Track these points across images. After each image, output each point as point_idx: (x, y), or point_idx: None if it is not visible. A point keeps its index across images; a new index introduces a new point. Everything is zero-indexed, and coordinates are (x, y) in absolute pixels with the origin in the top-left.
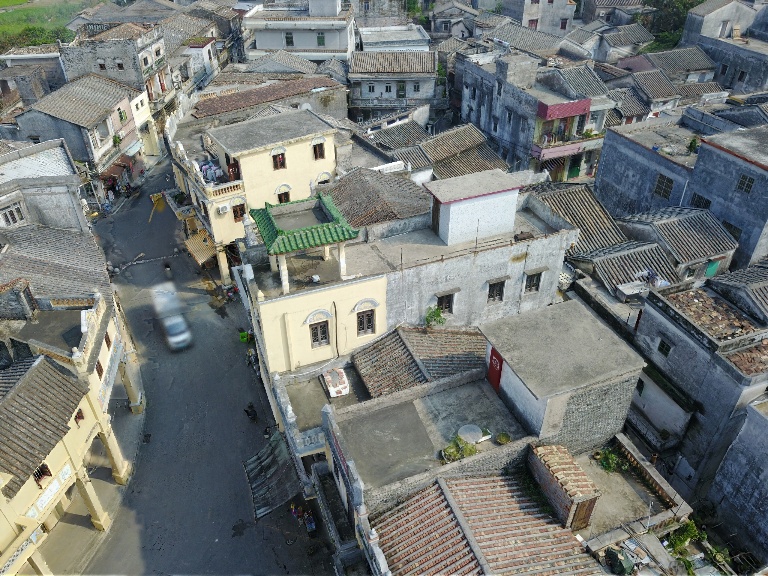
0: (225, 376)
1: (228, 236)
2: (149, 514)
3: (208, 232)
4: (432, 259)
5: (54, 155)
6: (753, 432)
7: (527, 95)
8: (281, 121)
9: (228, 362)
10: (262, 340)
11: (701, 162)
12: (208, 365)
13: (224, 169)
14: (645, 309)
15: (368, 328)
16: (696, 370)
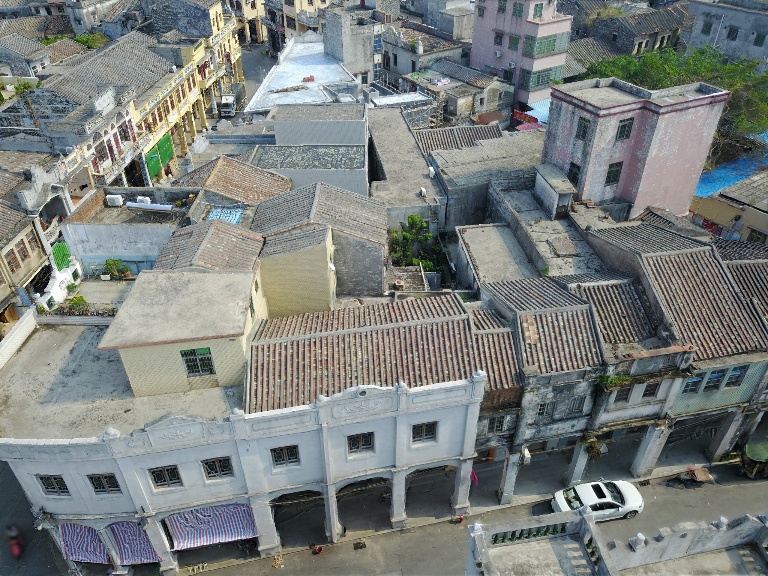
0: (263, 60)
1: (249, 16)
2: (256, 80)
3: (239, 16)
4: None
5: None
6: (430, 5)
7: None
8: None
9: (262, 58)
10: (291, 7)
11: None
12: (254, 59)
13: None
14: None
15: (323, 2)
16: (420, 3)
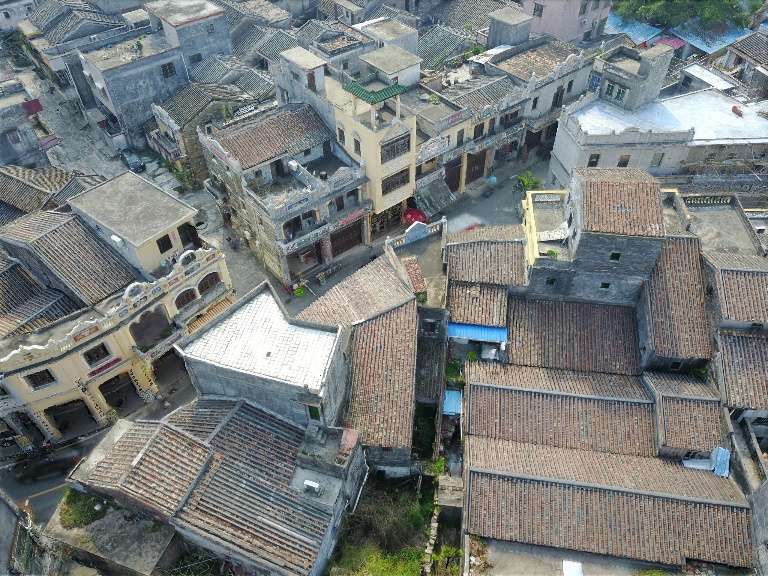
0: None
1: None
2: None
3: None
4: (341, 91)
5: (209, 342)
6: None
7: (1, 110)
8: (106, 207)
9: None
10: (401, 156)
11: (182, 38)
12: None
13: (155, 266)
14: (331, 61)
15: None
16: None
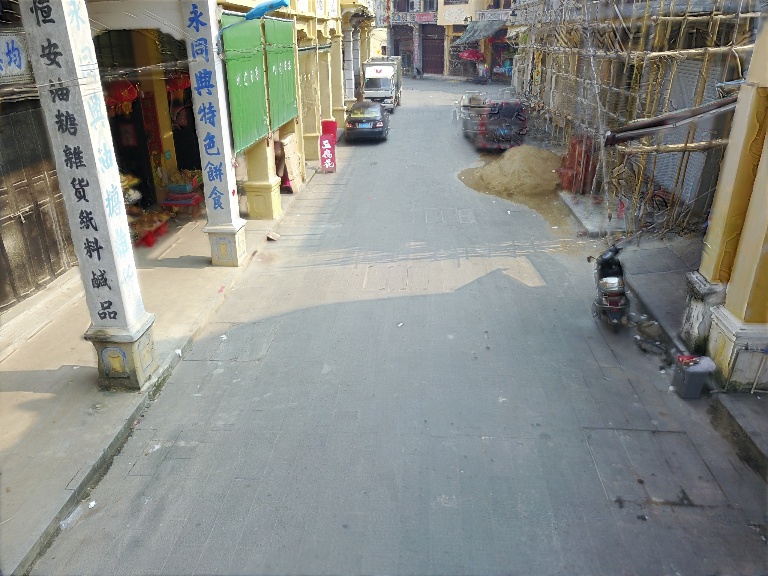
0: None
1: None
2: None
3: None
4: None
5: None
6: None
7: None
8: None
9: None
10: None
11: None
12: None
13: None
14: None
15: None
16: None
